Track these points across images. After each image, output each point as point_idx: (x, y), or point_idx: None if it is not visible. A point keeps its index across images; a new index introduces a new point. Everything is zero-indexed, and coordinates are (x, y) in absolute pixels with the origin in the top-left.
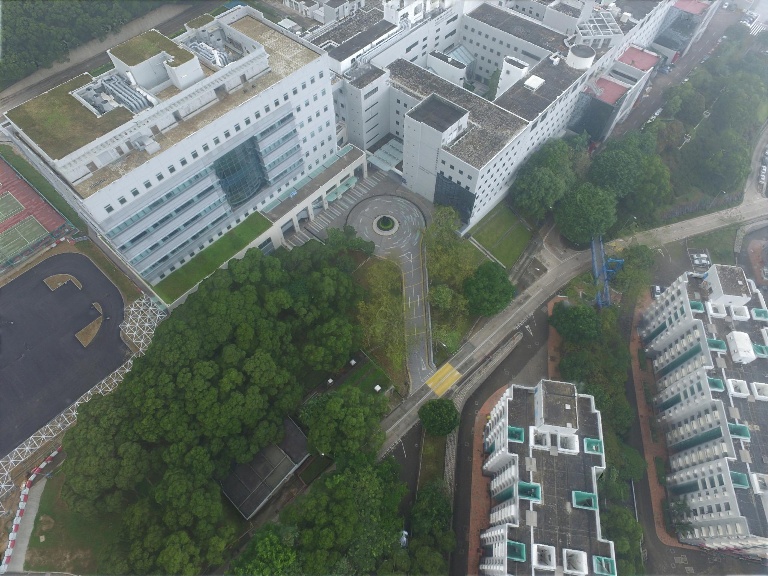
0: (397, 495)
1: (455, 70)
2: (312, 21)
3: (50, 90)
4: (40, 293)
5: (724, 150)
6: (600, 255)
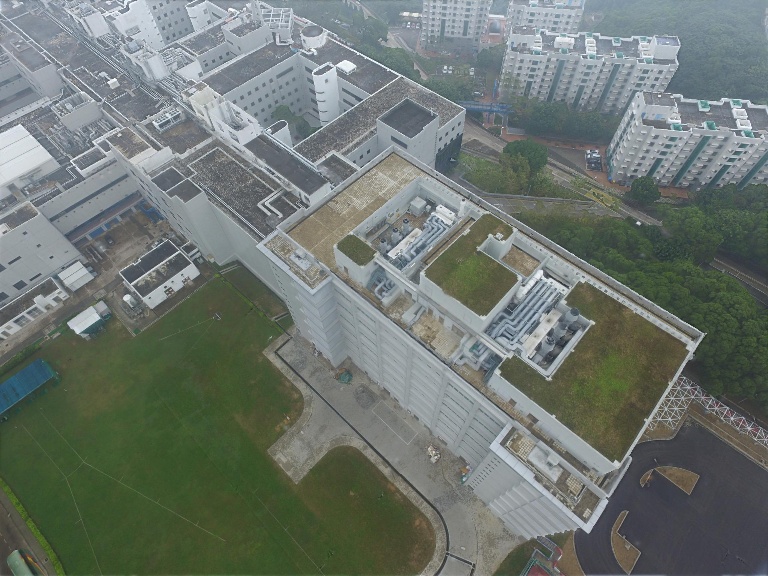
0: (730, 198)
1: (284, 131)
2: (79, 294)
3: (548, 412)
4: (649, 572)
5: (363, 26)
6: (467, 104)
